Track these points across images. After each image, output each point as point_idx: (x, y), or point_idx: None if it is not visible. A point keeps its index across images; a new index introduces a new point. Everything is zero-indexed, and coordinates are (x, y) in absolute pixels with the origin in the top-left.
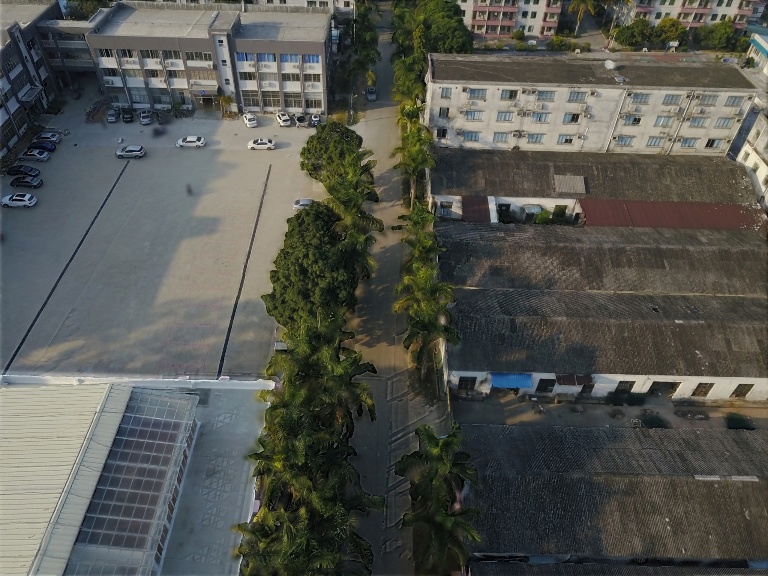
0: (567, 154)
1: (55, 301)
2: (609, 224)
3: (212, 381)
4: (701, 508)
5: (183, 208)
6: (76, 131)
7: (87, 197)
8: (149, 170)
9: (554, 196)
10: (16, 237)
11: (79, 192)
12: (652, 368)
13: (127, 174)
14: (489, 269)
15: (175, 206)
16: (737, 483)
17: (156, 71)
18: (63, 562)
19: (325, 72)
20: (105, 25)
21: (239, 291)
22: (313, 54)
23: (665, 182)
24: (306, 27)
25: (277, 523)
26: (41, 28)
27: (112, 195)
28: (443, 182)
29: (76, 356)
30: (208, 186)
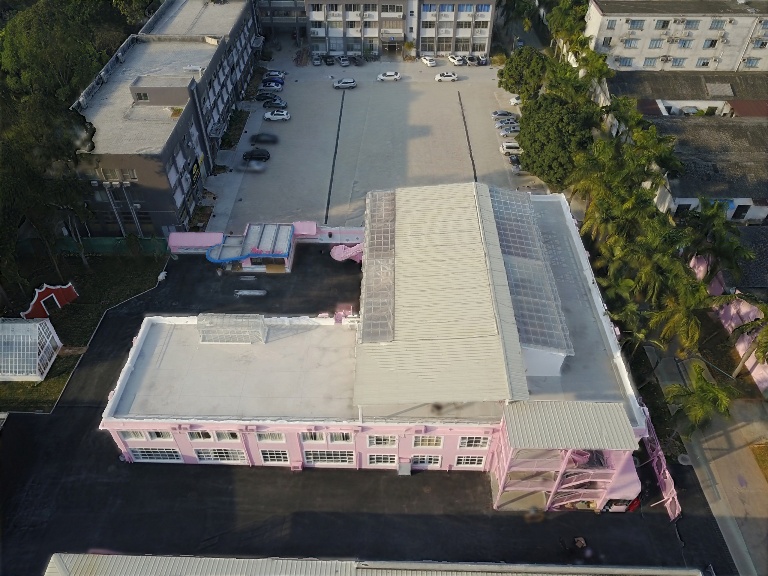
0: (709, 71)
1: (338, 177)
2: (758, 115)
3: None
4: None
5: (404, 120)
6: (292, 72)
7: (325, 114)
8: (364, 96)
9: (708, 99)
10: (286, 139)
11: (317, 111)
12: None
13: (348, 99)
14: (678, 141)
15: (397, 119)
16: None
17: (354, 22)
18: (501, 260)
19: (493, 19)
20: None
21: (474, 170)
22: (485, 4)
23: None
24: None
25: None
26: None
27: (344, 113)
28: (619, 90)
29: None
30: (416, 105)
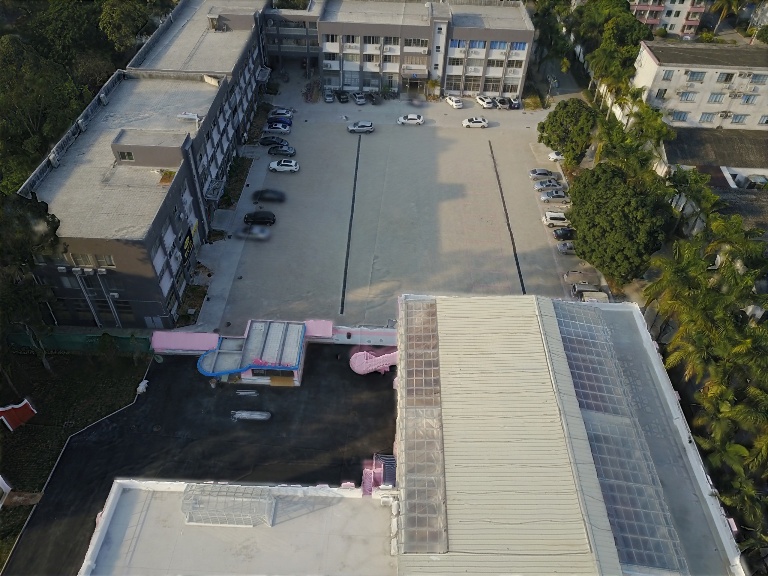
0: None
1: (356, 249)
2: None
3: (583, 302)
4: None
5: (430, 175)
6: (301, 109)
7: (339, 165)
8: (383, 143)
9: None
10: (295, 197)
11: (330, 161)
12: None
13: (364, 146)
14: (755, 225)
15: (422, 174)
16: None
17: (372, 56)
18: (581, 420)
19: (528, 59)
20: (324, 14)
21: (513, 244)
22: (521, 42)
23: None
24: (505, 18)
25: (735, 398)
26: (267, 16)
27: (360, 164)
28: (677, 153)
29: (398, 293)
30: (443, 157)
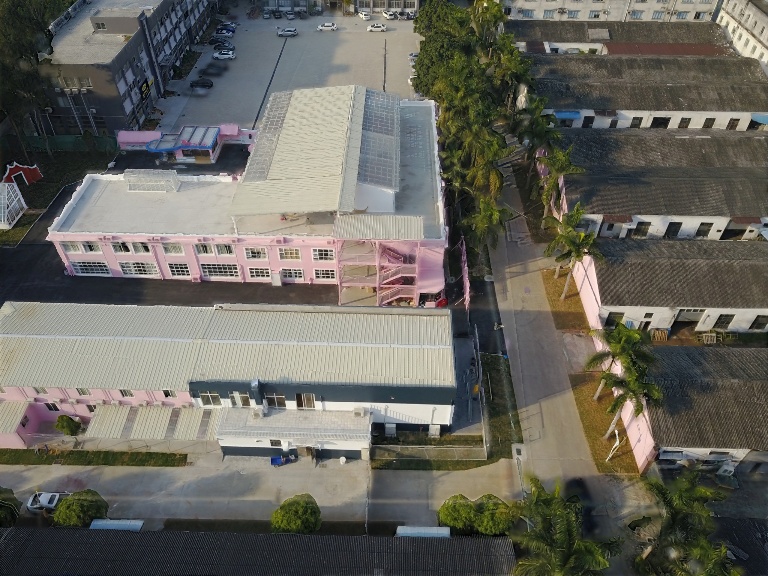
0: (596, 21)
1: None
2: (626, 53)
3: None
4: (678, 149)
5: (333, 60)
6: (244, 23)
7: (267, 55)
8: (303, 42)
9: (588, 41)
10: (230, 73)
11: (260, 53)
12: (653, 107)
13: (288, 45)
14: (549, 70)
15: (328, 59)
16: (699, 139)
17: None
18: (360, 133)
19: None
20: None
21: None
22: None
23: (664, 32)
24: None
25: None
26: None
27: (283, 55)
28: None
29: None
30: (346, 50)
